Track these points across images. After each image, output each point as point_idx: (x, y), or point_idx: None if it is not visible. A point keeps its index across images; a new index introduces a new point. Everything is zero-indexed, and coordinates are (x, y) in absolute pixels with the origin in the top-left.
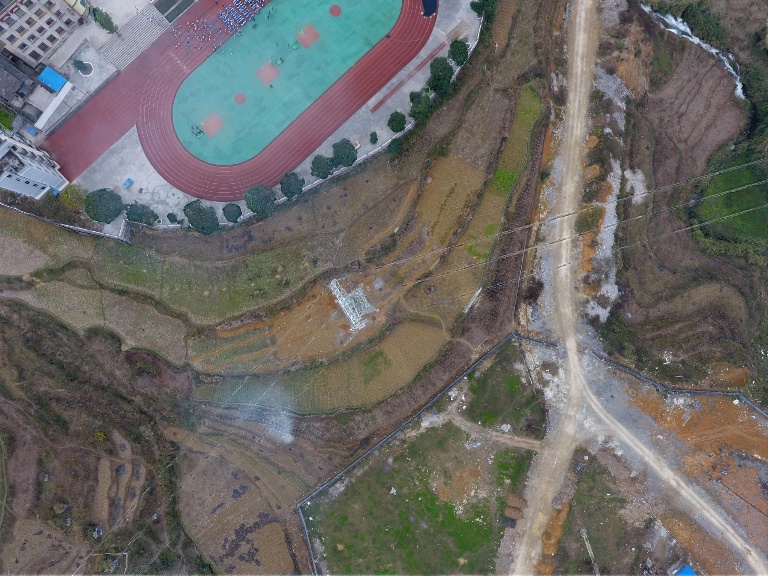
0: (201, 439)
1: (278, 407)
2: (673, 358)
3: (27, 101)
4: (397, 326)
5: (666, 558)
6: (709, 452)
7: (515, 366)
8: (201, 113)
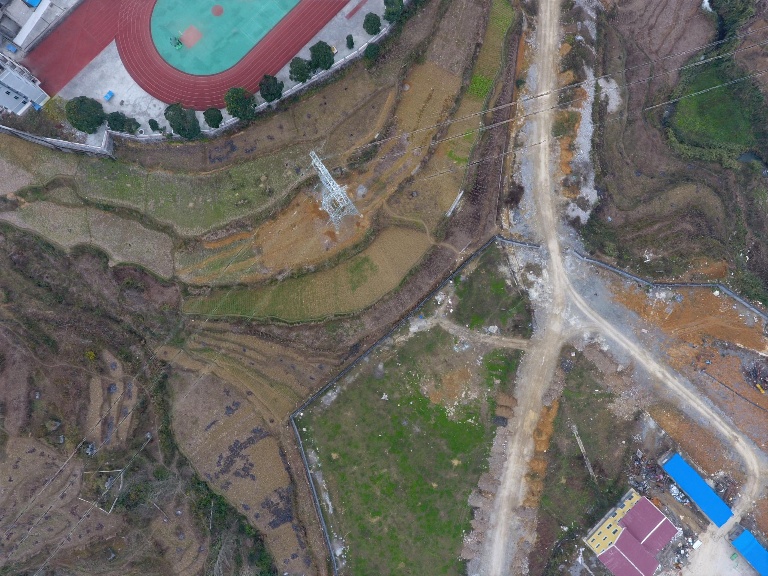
0: (192, 356)
1: (267, 317)
2: (654, 256)
3: (5, 12)
4: (381, 232)
5: (656, 449)
6: (693, 343)
7: (499, 269)
8: (179, 25)
